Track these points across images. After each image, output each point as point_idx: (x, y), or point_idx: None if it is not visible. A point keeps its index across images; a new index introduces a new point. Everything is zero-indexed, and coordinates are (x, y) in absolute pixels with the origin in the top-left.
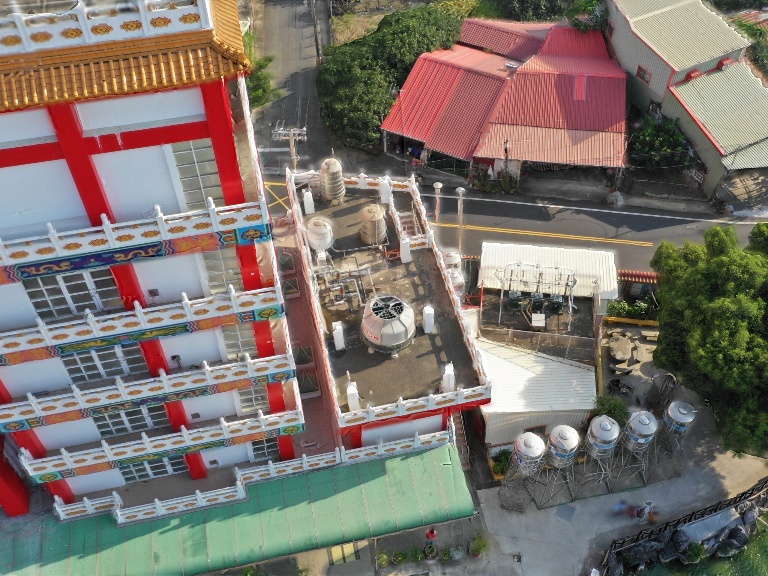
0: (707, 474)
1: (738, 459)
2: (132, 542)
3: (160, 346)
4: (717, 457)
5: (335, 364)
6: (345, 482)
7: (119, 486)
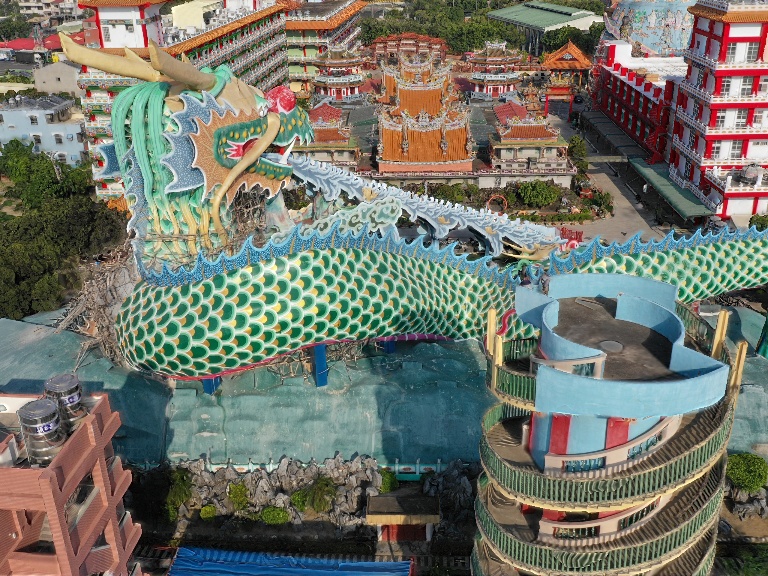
0: (733, 294)
1: (745, 302)
2: (663, 178)
3: (702, 113)
4: (744, 298)
5: (733, 176)
6: (693, 200)
7: (681, 172)
